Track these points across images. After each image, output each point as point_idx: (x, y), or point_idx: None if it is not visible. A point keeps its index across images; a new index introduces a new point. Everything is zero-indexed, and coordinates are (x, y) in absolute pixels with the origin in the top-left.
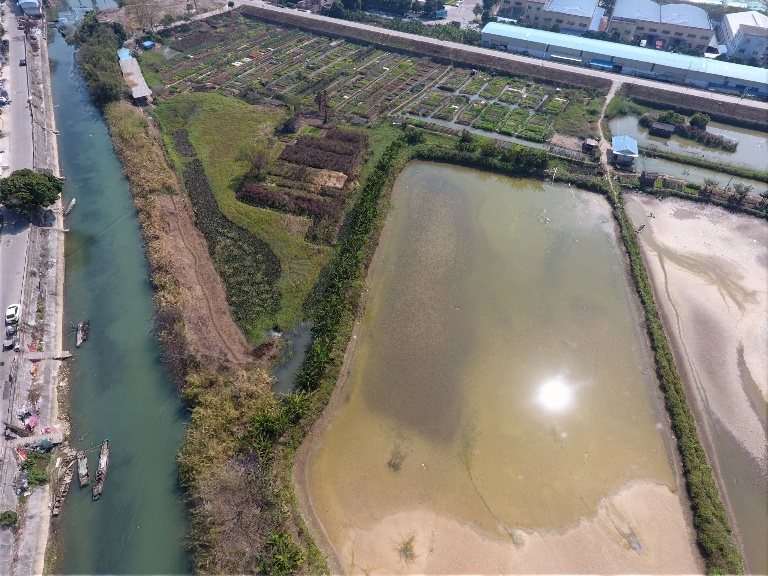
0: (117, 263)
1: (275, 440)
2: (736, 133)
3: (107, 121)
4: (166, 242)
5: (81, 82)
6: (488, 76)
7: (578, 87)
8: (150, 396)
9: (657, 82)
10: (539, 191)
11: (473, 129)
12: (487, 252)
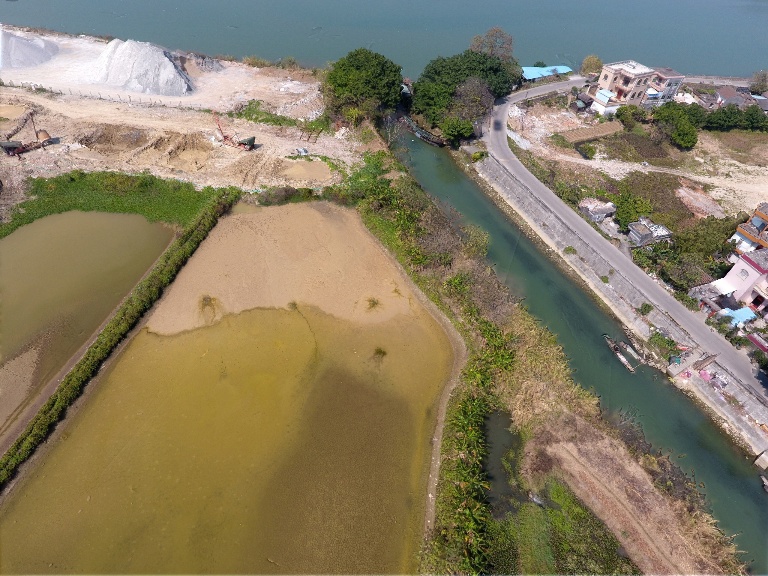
0: None
1: None
2: None
3: None
4: None
5: None
6: None
7: None
8: None
9: None
10: None
11: None
12: None
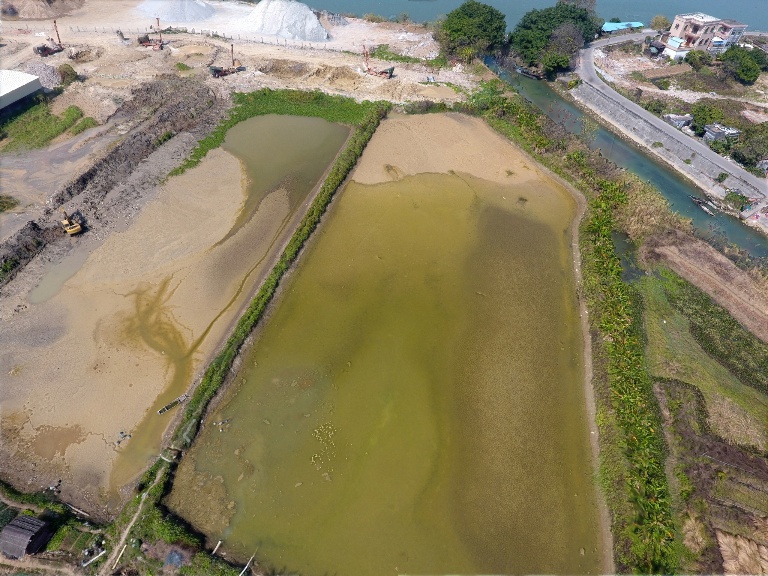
0: None
1: None
2: None
3: None
4: None
5: None
6: None
7: None
8: None
9: None
10: None
11: None
12: (436, 367)
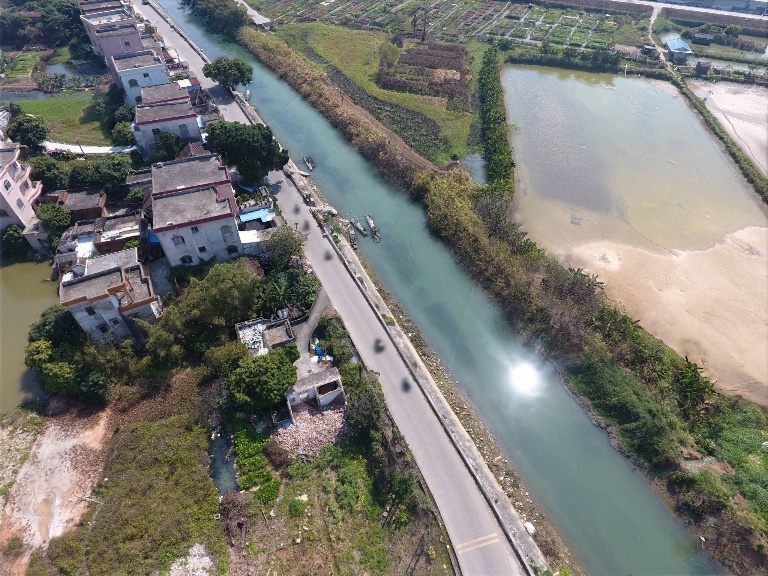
0: (308, 126)
1: None
2: None
3: (243, 41)
4: (345, 109)
5: (203, 16)
6: (544, 8)
7: (624, 13)
8: (382, 194)
9: (691, 6)
10: (611, 86)
11: None
12: (591, 116)
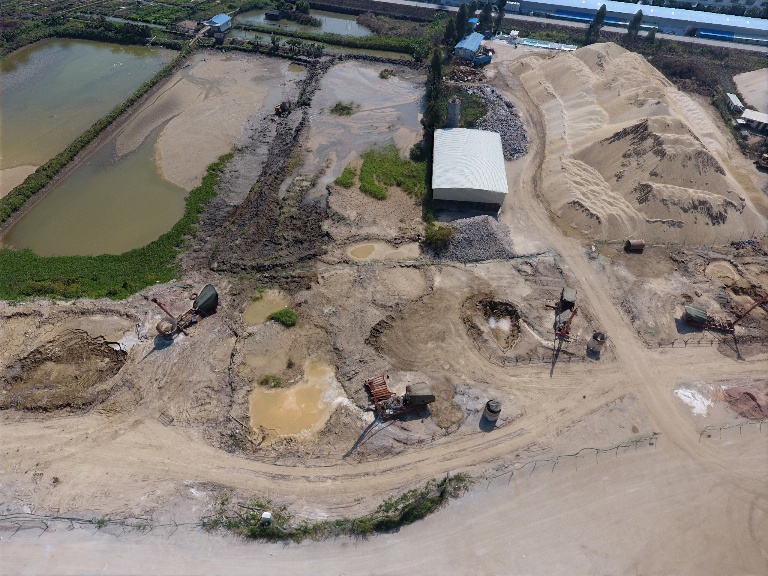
0: None
1: None
2: None
3: None
4: None
5: None
6: None
7: None
8: None
9: None
10: None
11: (123, 20)
12: (50, 80)
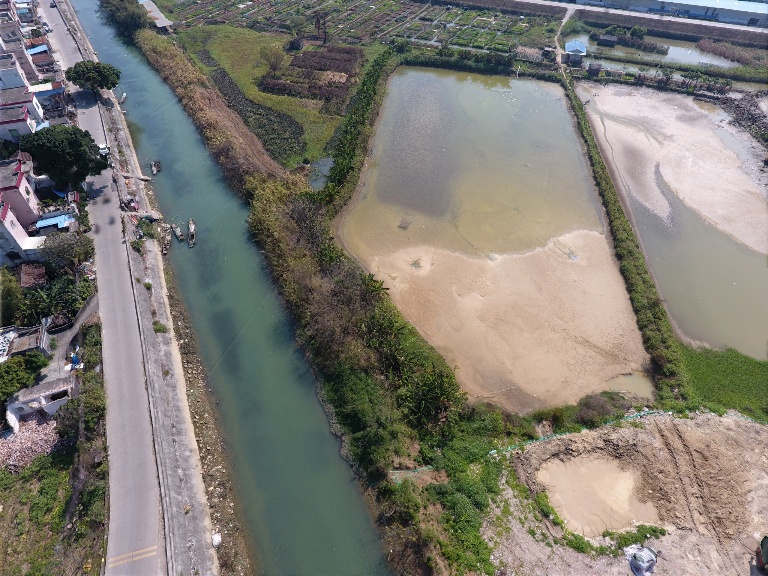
0: (171, 130)
1: (316, 211)
2: (671, 47)
3: (138, 43)
4: (210, 112)
5: (108, 18)
6: (462, 10)
7: (539, 15)
8: (217, 198)
9: (605, 8)
10: (507, 88)
11: (450, 45)
12: (465, 118)
